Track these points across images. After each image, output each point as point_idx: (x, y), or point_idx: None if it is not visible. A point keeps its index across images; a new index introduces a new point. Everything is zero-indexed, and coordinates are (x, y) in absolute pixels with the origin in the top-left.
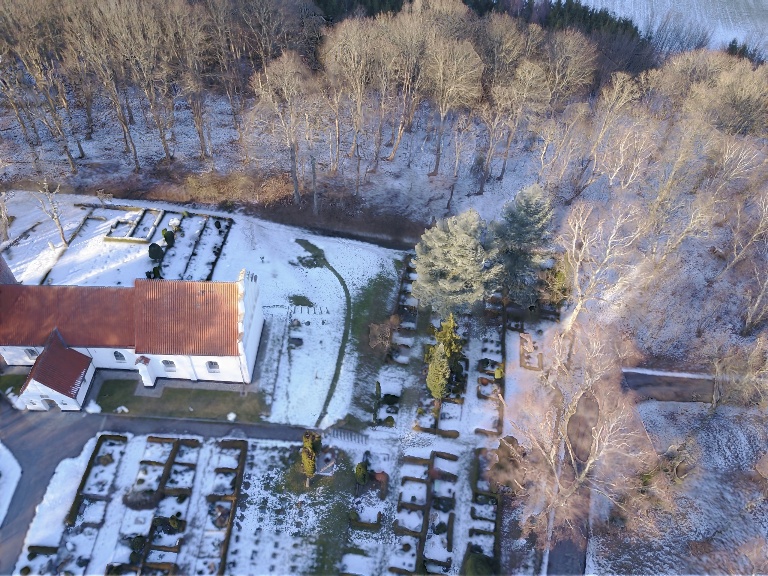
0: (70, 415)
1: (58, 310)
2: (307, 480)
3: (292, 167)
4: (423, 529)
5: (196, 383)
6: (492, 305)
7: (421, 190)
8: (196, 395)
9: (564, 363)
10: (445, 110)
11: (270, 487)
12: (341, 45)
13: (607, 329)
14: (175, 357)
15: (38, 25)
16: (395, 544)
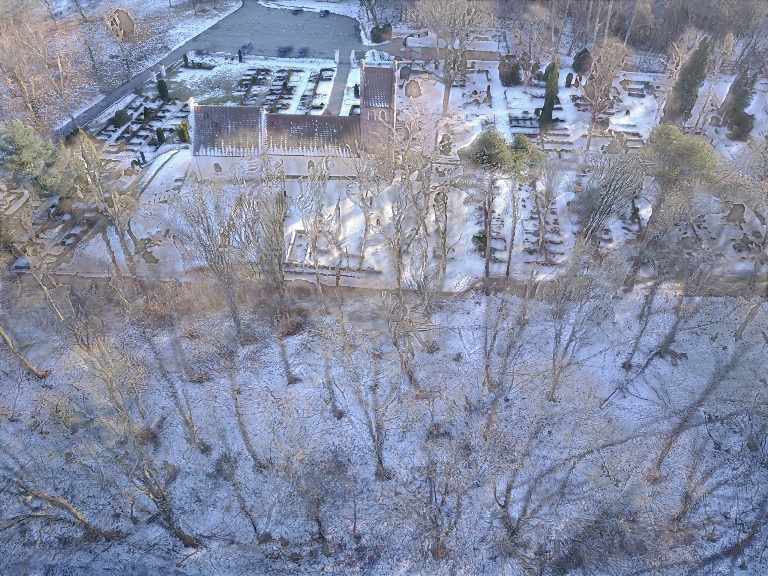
0: None
1: None
2: None
3: None
4: (139, 129)
5: None
6: (8, 231)
7: None
8: None
9: None
10: None
11: None
12: None
13: None
14: None
15: None
16: None
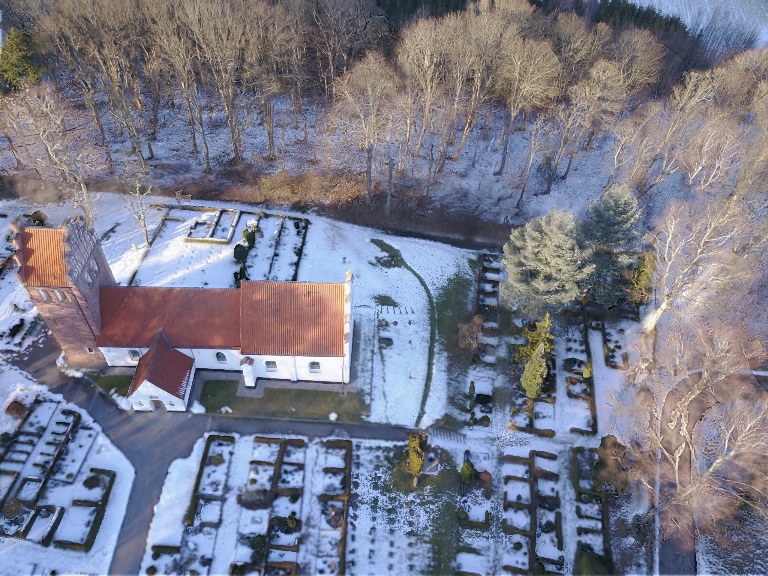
0: (176, 415)
1: (164, 311)
2: (415, 479)
3: (368, 167)
4: (532, 528)
5: (295, 383)
6: (571, 304)
7: (489, 190)
8: (297, 395)
9: (650, 362)
10: (516, 110)
11: (379, 486)
12: (414, 45)
13: (731, 329)
14: (279, 358)
15: (124, 27)
16: (506, 543)
